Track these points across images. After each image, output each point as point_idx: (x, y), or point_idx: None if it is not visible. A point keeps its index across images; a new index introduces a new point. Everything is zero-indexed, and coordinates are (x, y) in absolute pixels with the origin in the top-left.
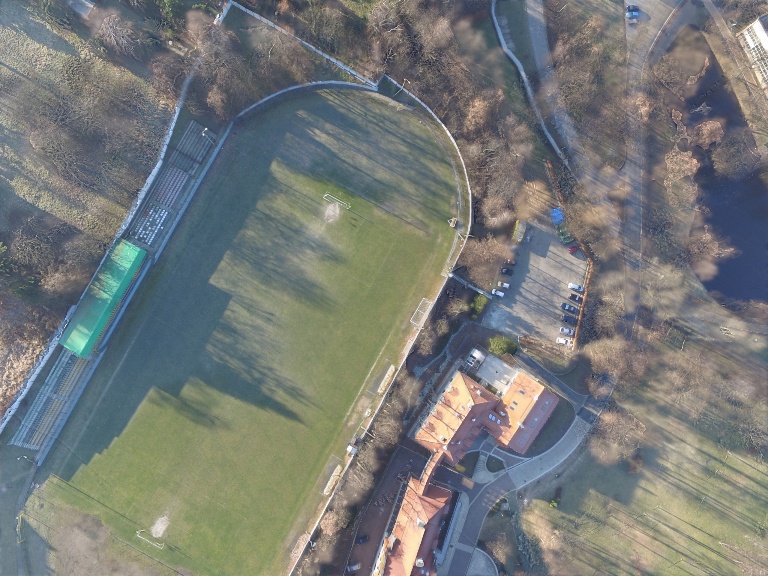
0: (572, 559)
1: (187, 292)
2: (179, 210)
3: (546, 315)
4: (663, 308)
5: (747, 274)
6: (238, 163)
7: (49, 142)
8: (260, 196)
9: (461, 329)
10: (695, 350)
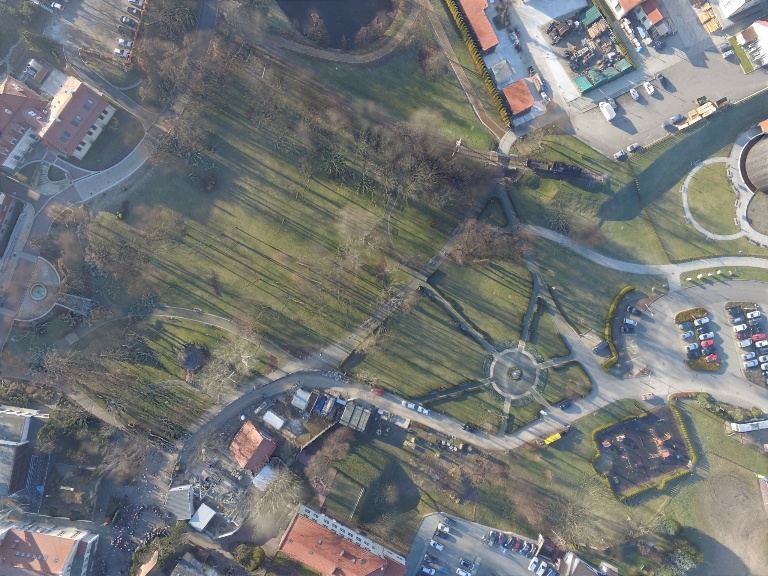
0: (146, 275)
1: None
2: None
3: (107, 29)
4: (241, 35)
5: (332, 8)
6: None
7: None
8: None
9: (21, 41)
10: (276, 77)
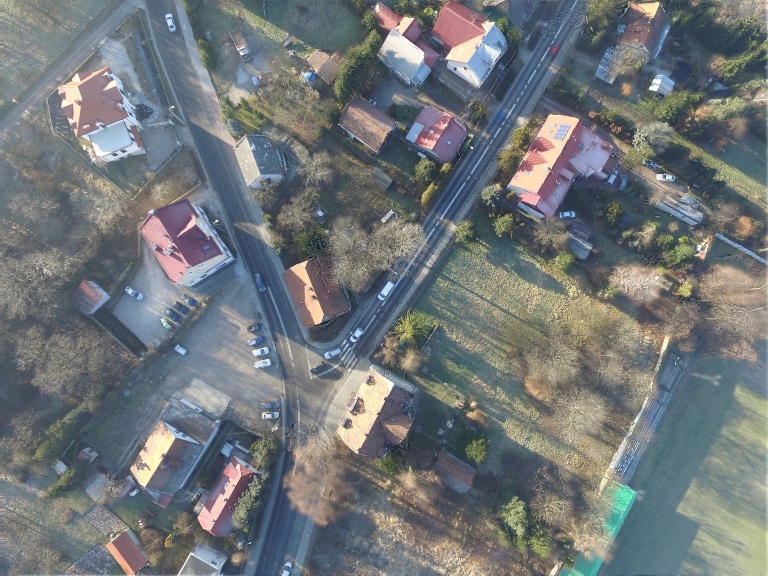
0: None
1: (654, 521)
2: (647, 439)
3: None
4: None
5: None
6: (701, 388)
7: (559, 392)
8: (724, 421)
9: None
10: None
